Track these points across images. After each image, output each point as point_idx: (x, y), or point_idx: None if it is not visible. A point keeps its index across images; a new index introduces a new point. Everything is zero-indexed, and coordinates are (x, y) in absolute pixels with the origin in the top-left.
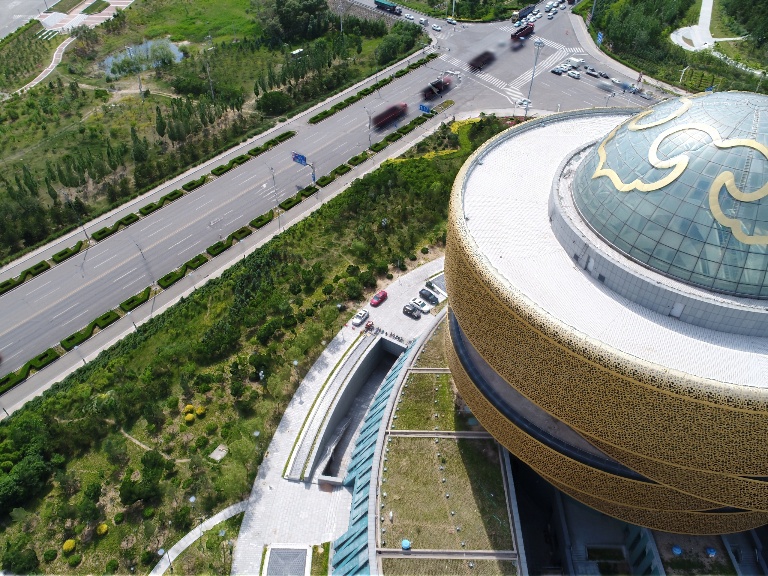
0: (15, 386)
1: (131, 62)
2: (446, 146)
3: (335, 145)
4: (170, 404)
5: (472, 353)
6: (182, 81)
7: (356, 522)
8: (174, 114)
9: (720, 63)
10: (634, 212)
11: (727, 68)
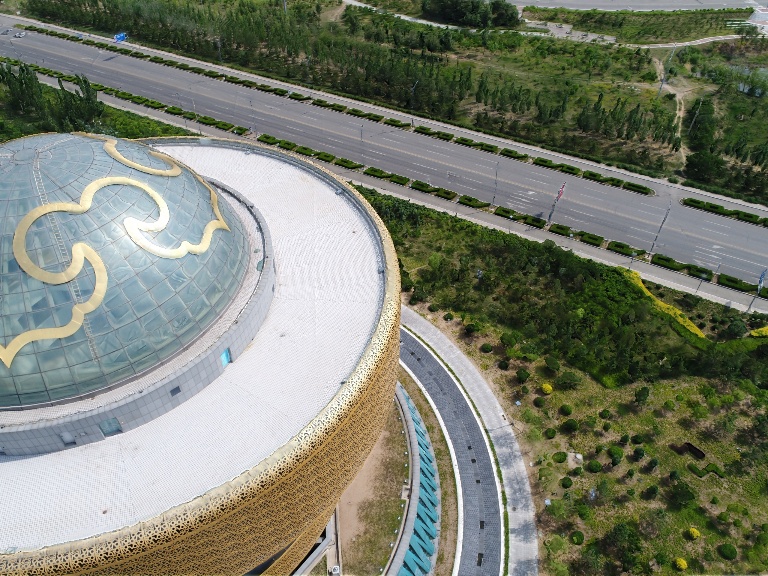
0: (265, 143)
1: (722, 71)
2: (714, 327)
3: (645, 227)
4: None
5: None
6: (703, 104)
7: None
8: (614, 110)
9: None
10: None
11: None
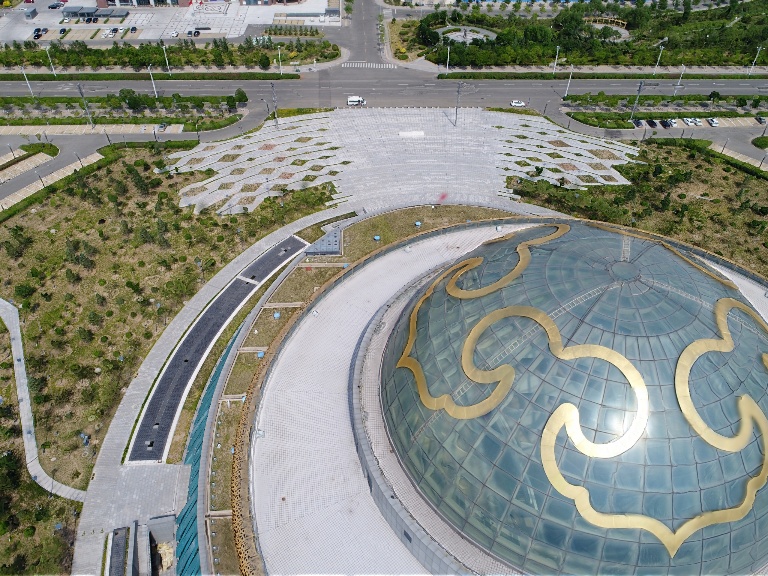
0: None
1: None
2: None
3: None
4: None
5: None
6: None
7: None
8: None
9: None
10: None
11: None
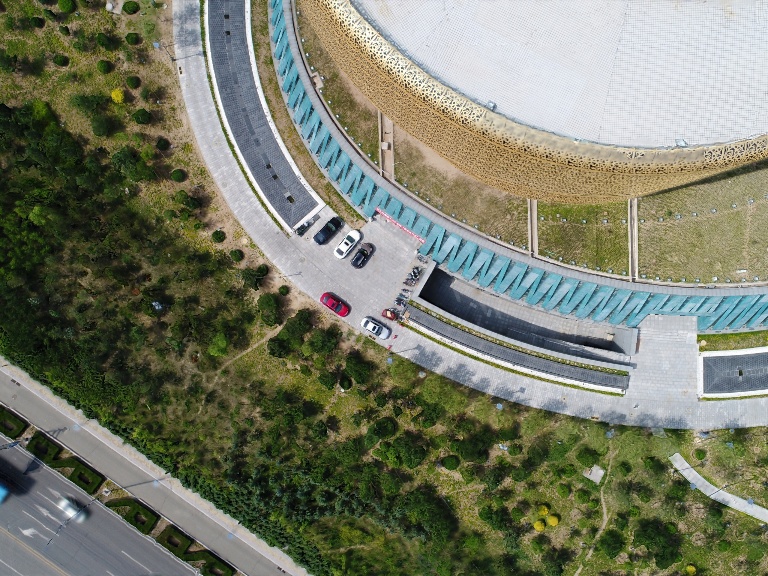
0: None
1: None
2: None
3: None
4: (542, 550)
5: None
6: None
7: (717, 309)
8: None
9: None
10: None
11: None
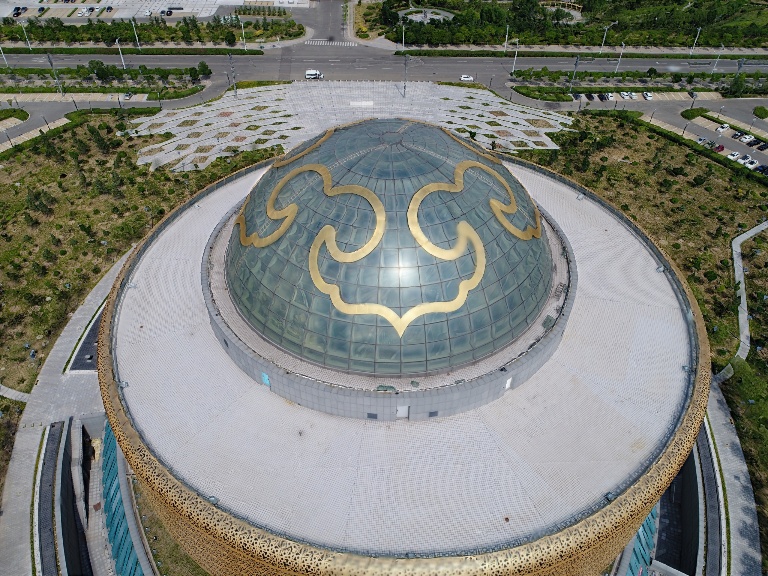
0: None
1: None
2: None
3: None
4: None
5: None
6: None
7: None
8: None
9: None
10: None
11: None
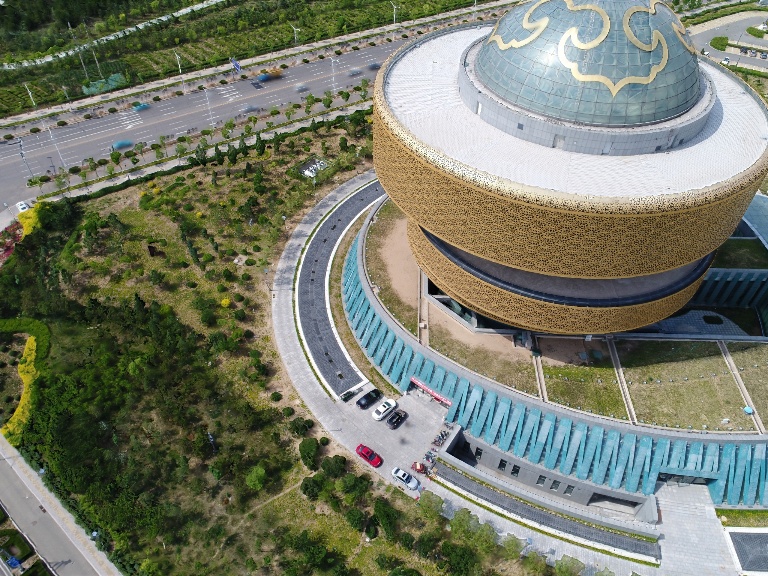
0: None
1: None
2: (5, 350)
3: None
4: None
5: (630, 294)
6: None
7: (719, 465)
8: None
9: (6, 72)
10: (668, 86)
11: (17, 73)
